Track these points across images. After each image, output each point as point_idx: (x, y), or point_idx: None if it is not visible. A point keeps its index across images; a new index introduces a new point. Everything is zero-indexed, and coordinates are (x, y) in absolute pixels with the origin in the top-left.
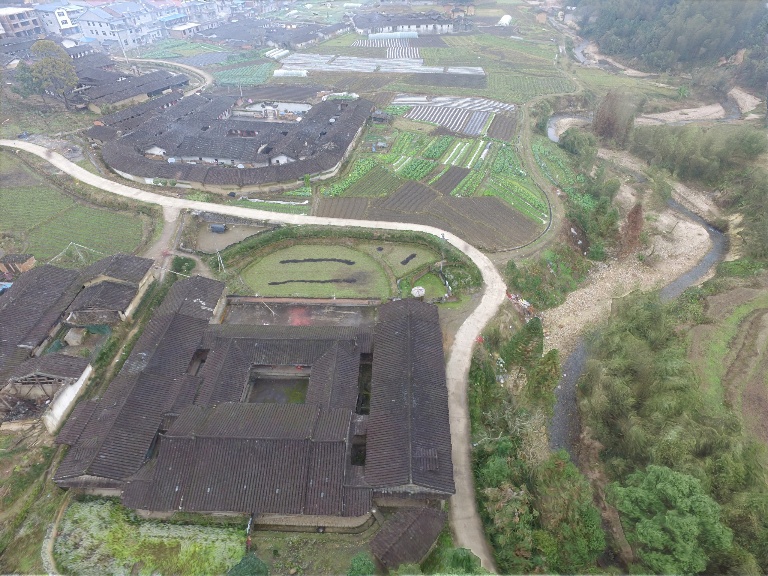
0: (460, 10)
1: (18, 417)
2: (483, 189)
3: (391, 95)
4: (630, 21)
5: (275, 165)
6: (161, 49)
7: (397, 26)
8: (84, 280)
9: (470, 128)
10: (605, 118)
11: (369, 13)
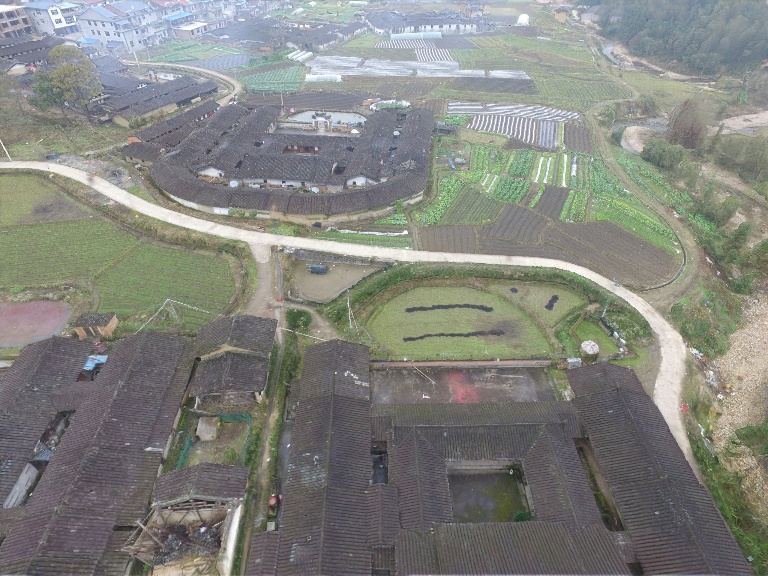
0: (478, 9)
1: (172, 556)
2: (593, 212)
3: (443, 102)
4: (663, 22)
5: (361, 189)
6: (171, 51)
7: (419, 26)
8: (204, 352)
9: (544, 140)
10: (688, 128)
11: (381, 12)
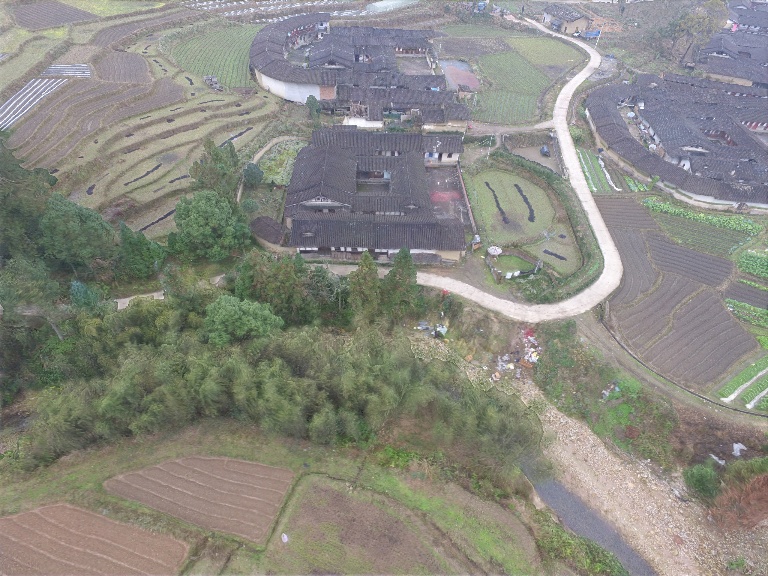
0: None
1: None
2: None
3: None
4: None
5: (656, 155)
6: None
7: None
8: None
9: None
10: None
11: None
